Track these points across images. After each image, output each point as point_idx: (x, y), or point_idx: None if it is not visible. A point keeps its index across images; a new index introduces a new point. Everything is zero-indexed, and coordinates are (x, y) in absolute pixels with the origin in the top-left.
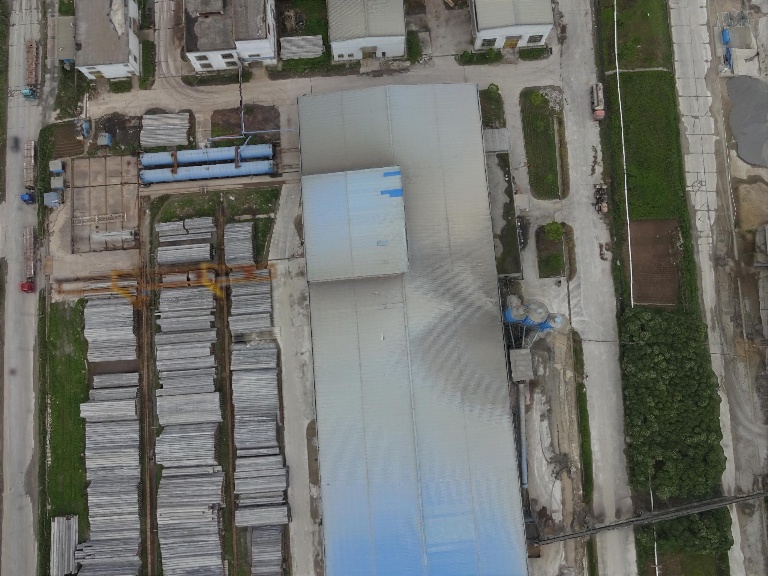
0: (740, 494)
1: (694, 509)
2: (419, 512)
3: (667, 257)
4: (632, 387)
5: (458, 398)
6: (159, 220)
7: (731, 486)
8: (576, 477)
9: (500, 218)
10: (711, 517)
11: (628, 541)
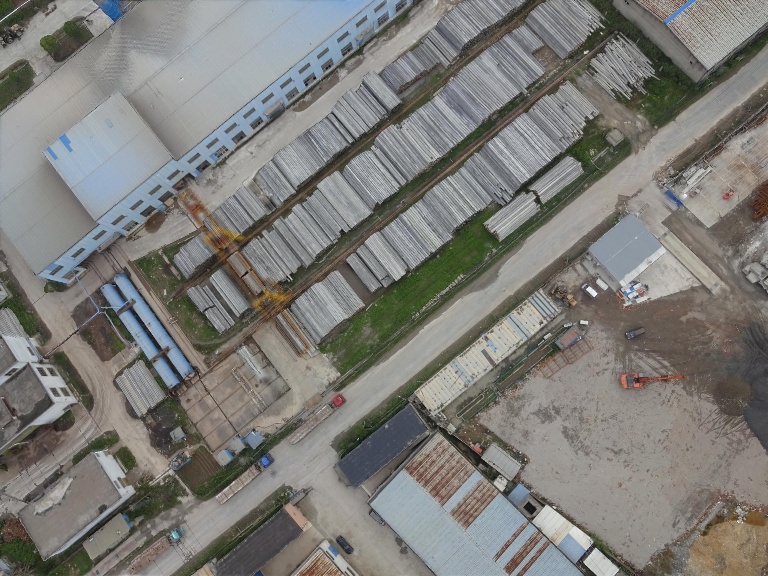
0: None
1: None
2: None
3: None
4: None
5: (192, 4)
6: (219, 338)
7: None
8: None
9: None
10: None
11: None
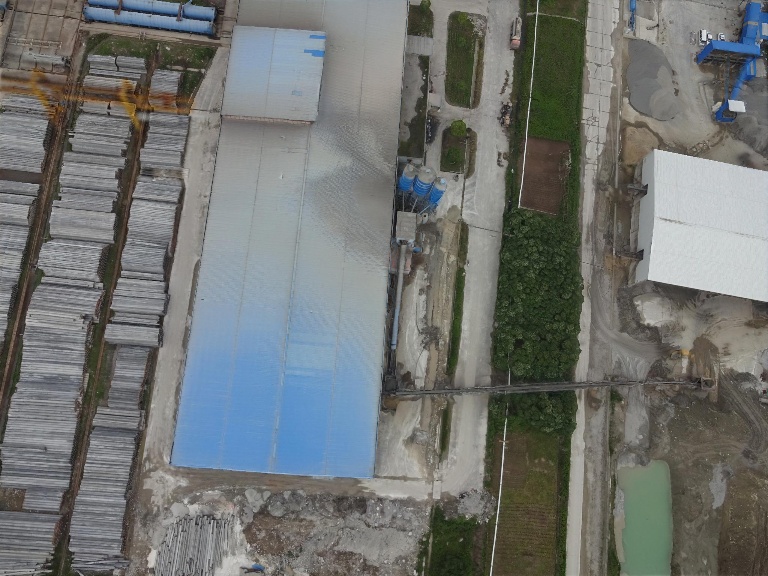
0: (587, 381)
1: (544, 386)
2: (285, 335)
3: (556, 173)
4: (506, 273)
5: (342, 242)
6: (93, 54)
7: (583, 380)
8: (443, 350)
9: (412, 109)
10: (559, 399)
11: (482, 415)
